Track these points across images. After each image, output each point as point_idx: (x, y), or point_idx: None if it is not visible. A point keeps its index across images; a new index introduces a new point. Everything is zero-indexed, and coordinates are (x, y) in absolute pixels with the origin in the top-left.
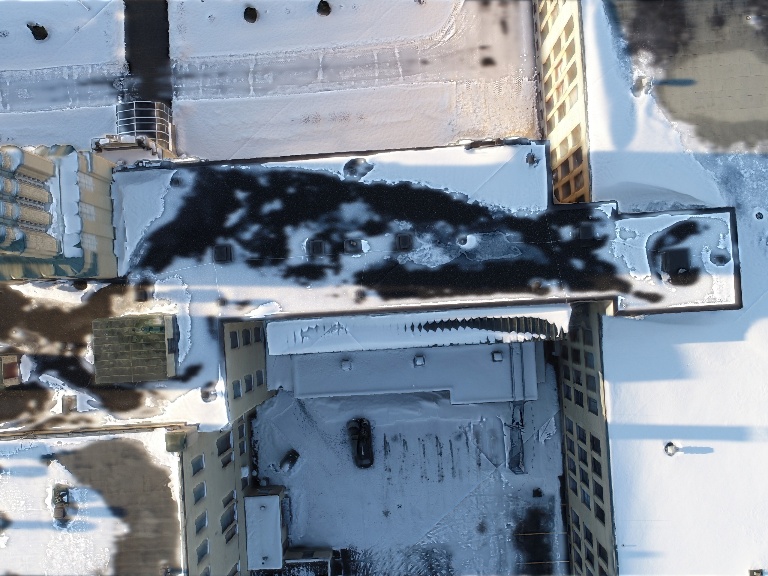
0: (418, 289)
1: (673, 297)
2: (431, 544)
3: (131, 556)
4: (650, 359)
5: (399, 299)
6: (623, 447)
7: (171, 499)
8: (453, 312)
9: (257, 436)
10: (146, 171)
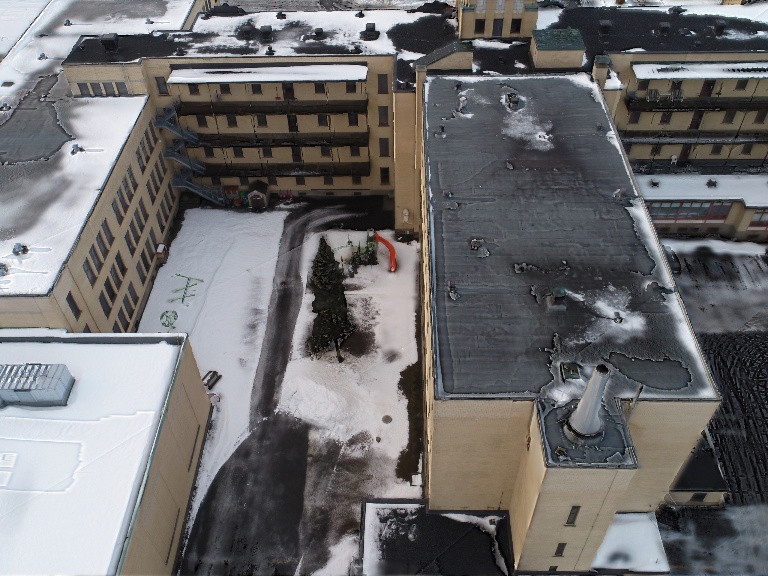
0: (734, 46)
1: None
2: (752, 331)
3: (570, 123)
4: None
5: (723, 49)
6: None
7: (595, 101)
8: (759, 64)
9: None
10: (547, 8)
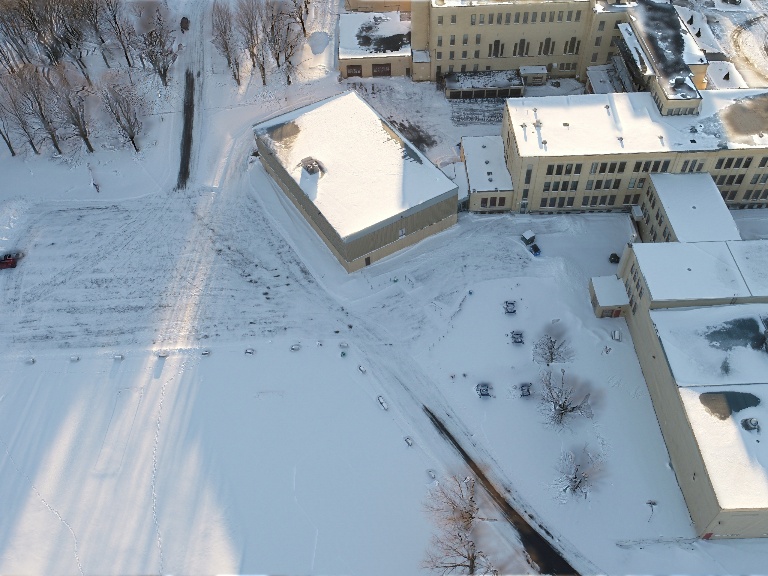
0: None
1: (666, 87)
2: None
3: None
4: (639, 102)
5: None
6: (605, 96)
7: (574, 0)
8: None
9: (563, 79)
10: None
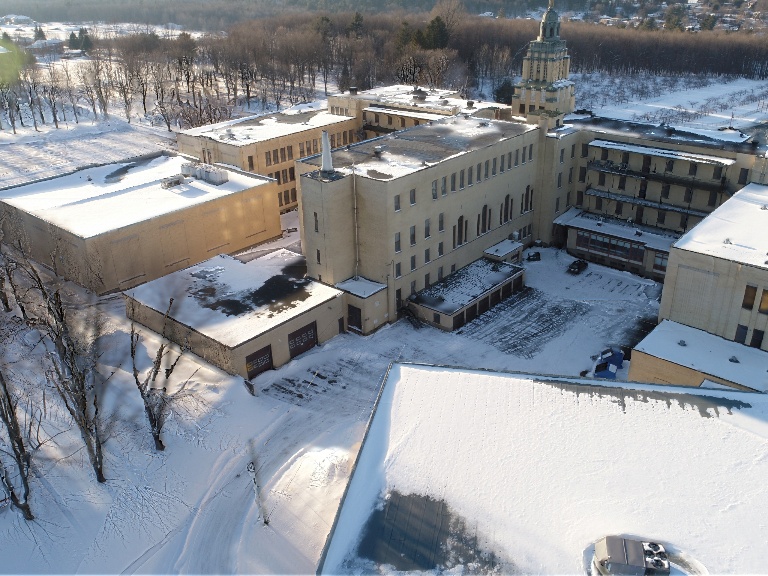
0: None
1: None
2: (583, 303)
3: None
4: None
5: None
6: (737, 201)
7: None
8: None
9: None
10: None
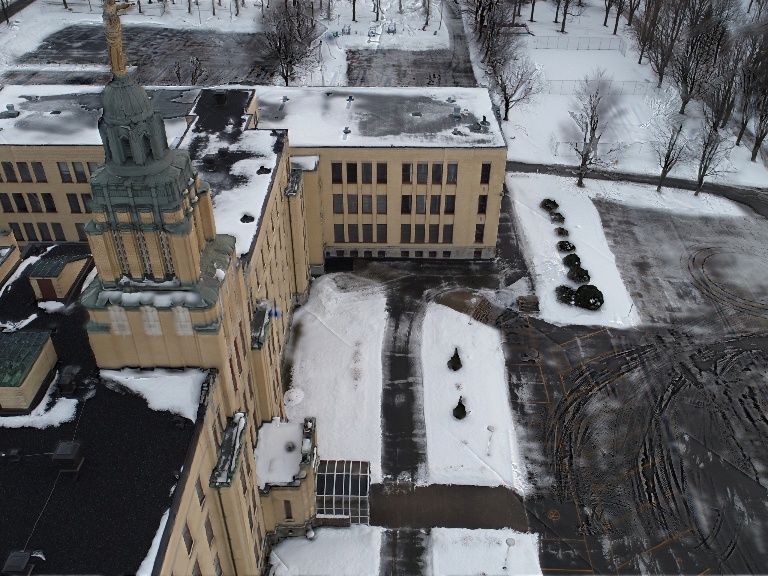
0: None
1: None
2: None
3: None
4: None
5: None
6: None
7: None
8: None
9: None
10: None
